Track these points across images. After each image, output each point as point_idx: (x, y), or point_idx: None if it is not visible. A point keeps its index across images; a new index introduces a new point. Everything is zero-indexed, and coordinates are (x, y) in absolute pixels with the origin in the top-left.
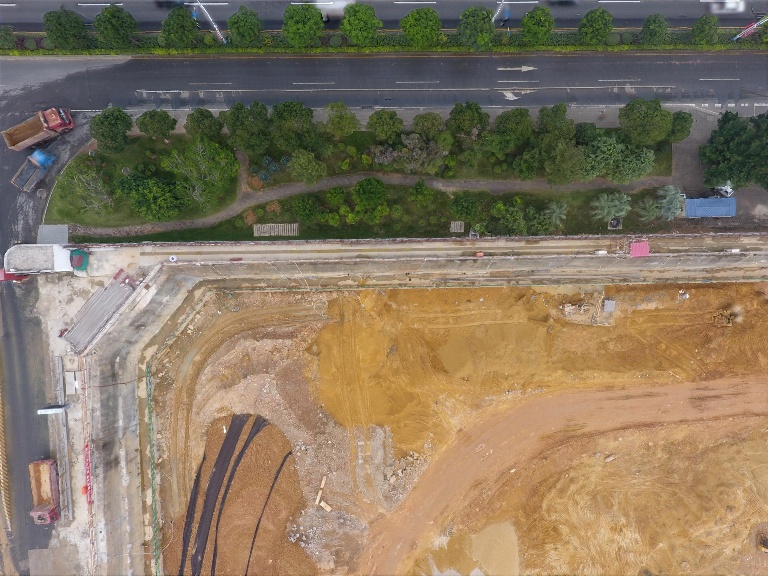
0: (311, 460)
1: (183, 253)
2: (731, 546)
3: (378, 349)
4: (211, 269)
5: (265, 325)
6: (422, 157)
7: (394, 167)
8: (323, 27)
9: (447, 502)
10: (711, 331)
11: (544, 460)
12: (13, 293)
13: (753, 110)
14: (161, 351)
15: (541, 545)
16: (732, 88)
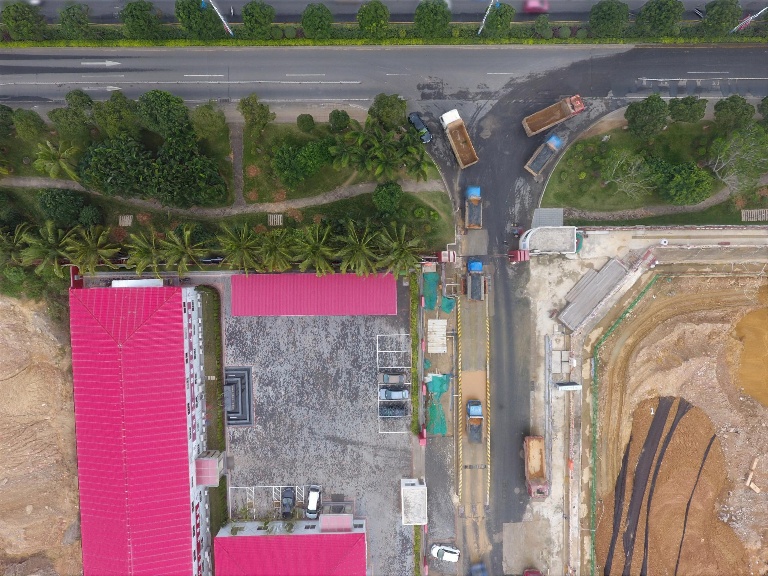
0: (742, 442)
1: (673, 237)
2: None
3: None
4: (692, 253)
5: (696, 310)
6: None
7: None
8: None
9: None
10: None
11: None
12: (506, 274)
13: None
14: (606, 333)
15: None
16: None
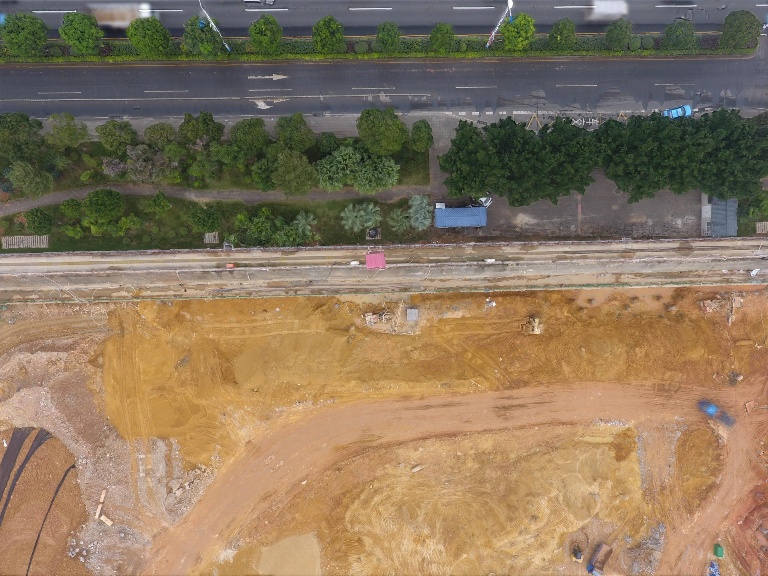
0: (91, 474)
1: None
2: (539, 556)
3: (165, 360)
4: None
5: (44, 337)
6: (148, 168)
7: None
8: (44, 36)
9: (234, 515)
10: (517, 339)
11: (337, 471)
12: None
13: (512, 118)
14: None
15: (344, 557)
16: (489, 96)
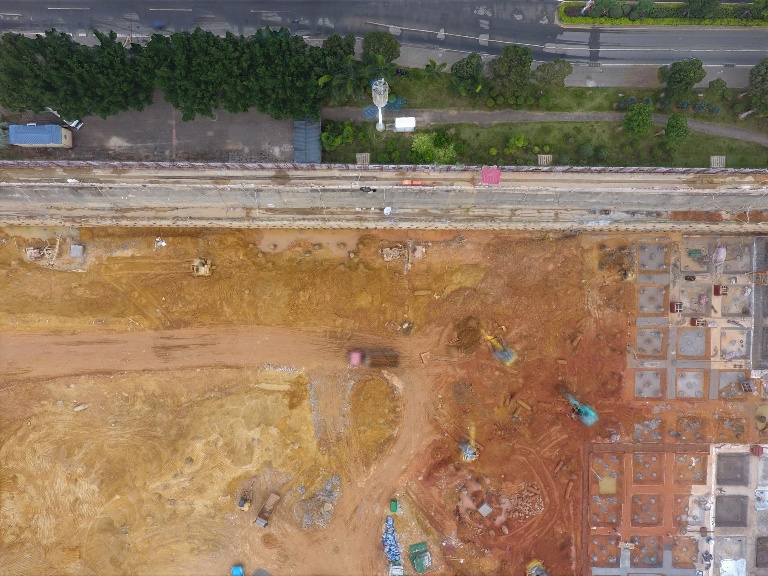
0: None
1: None
2: (198, 502)
3: None
4: None
5: None
6: None
7: None
8: None
9: None
10: (185, 280)
11: None
12: None
13: None
14: None
15: None
16: (83, 18)
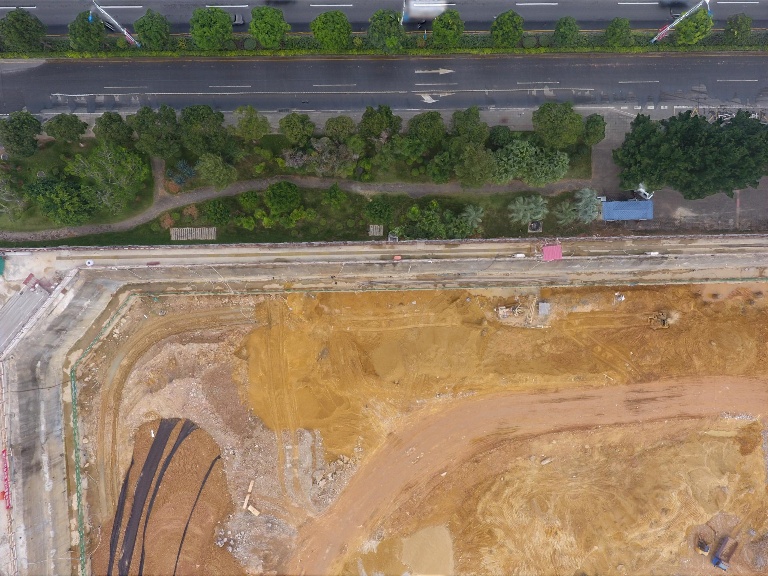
0: (239, 464)
1: (100, 257)
2: (667, 549)
3: (308, 352)
4: (129, 273)
5: (192, 329)
6: (332, 161)
7: (307, 171)
8: (231, 30)
9: (377, 506)
10: (647, 333)
11: (476, 463)
12: None
13: (673, 112)
14: (86, 355)
15: (476, 548)
16: (651, 90)
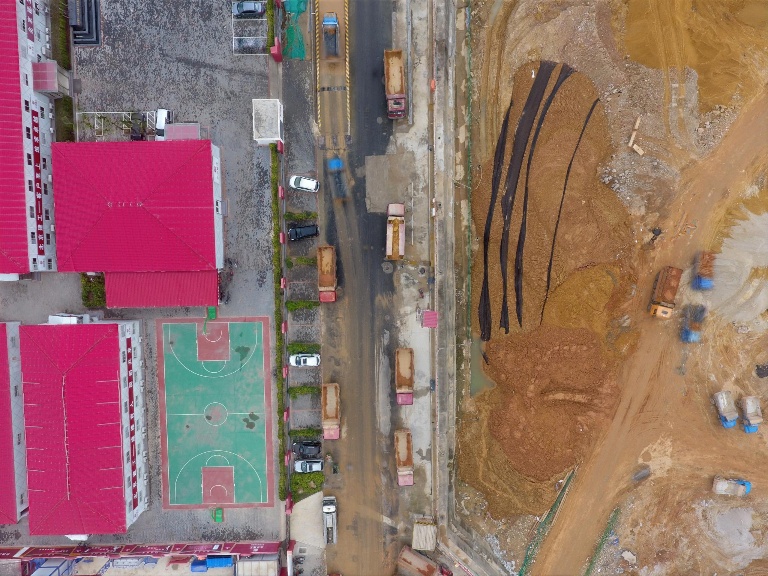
0: (624, 102)
1: None
2: None
3: (684, 1)
4: None
5: None
6: None
7: None
8: None
9: (757, 153)
10: None
11: None
12: None
13: None
14: None
15: None
16: None
